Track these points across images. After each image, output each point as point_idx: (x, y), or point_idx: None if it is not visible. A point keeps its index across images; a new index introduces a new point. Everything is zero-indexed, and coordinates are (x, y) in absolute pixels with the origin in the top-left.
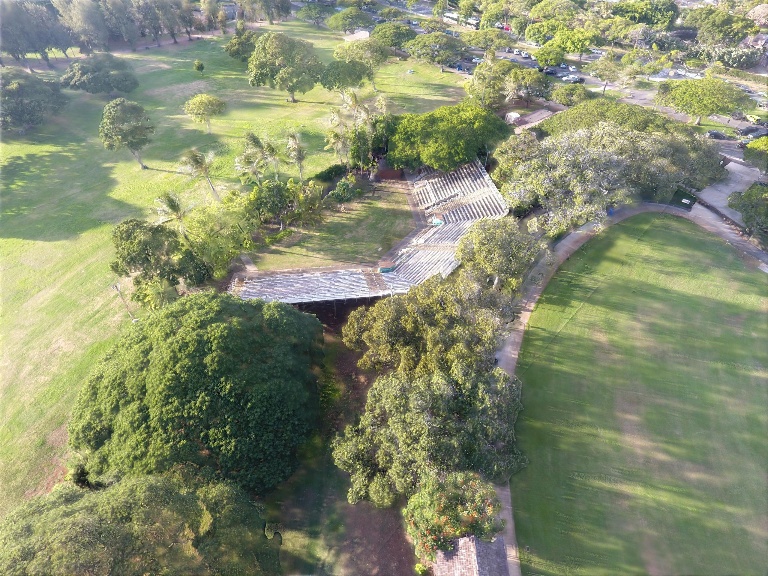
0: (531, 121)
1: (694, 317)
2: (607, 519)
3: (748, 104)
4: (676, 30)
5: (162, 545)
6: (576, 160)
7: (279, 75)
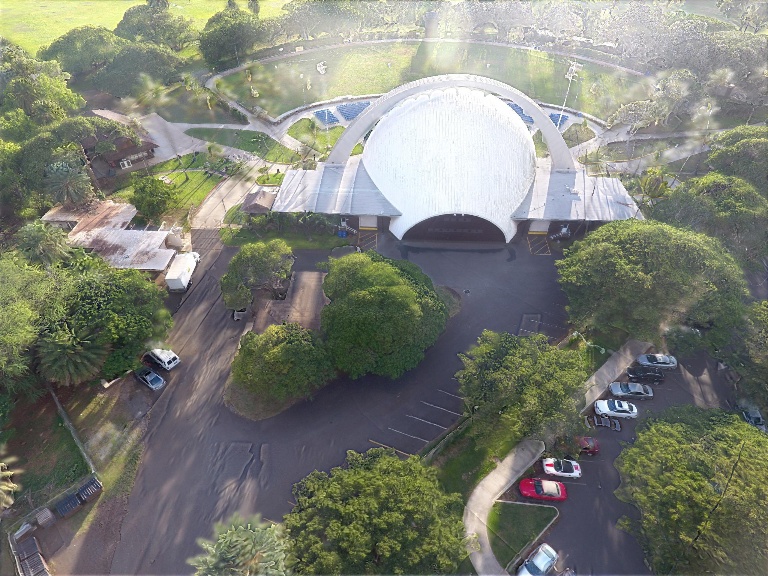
0: None
1: None
2: None
3: None
4: None
5: (434, 4)
6: None
7: (727, 0)
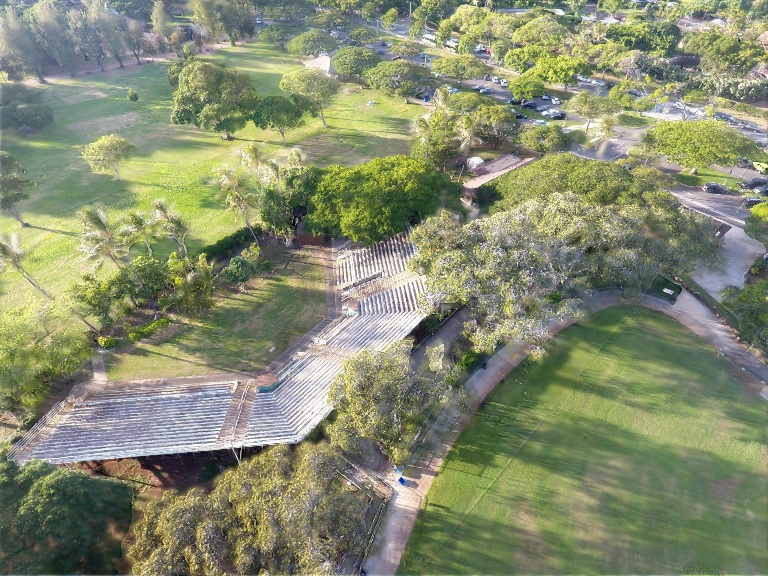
0: (493, 170)
1: (666, 483)
2: None
3: (754, 154)
4: (677, 56)
5: None
6: (509, 256)
7: (203, 112)
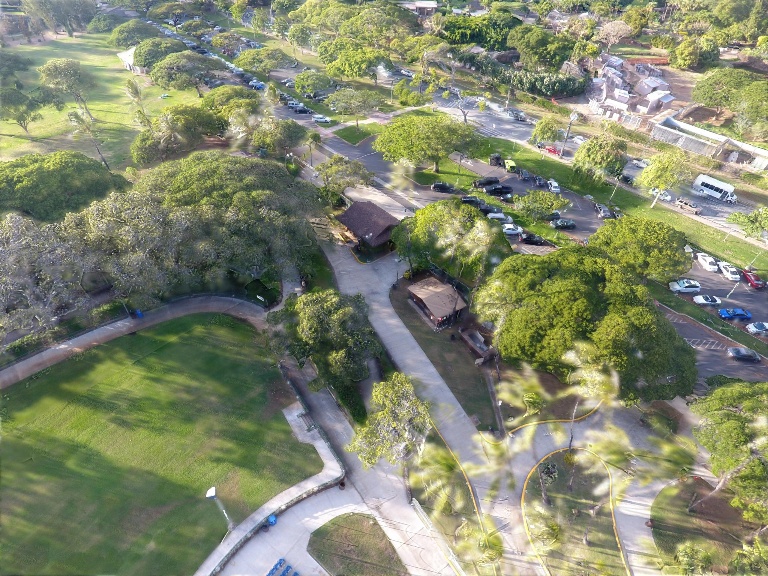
0: None
1: (80, 511)
2: None
3: (472, 151)
4: (509, 50)
5: None
6: None
7: None
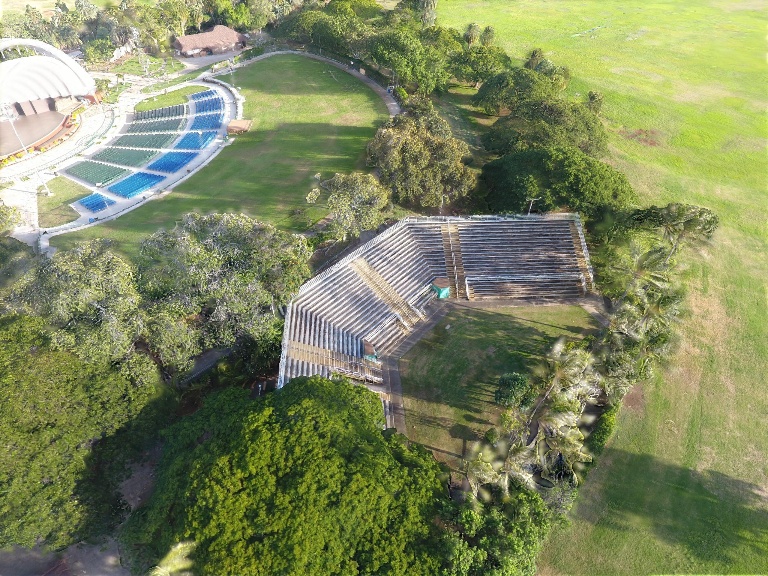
0: None
1: None
2: None
3: None
4: None
5: None
6: None
7: None
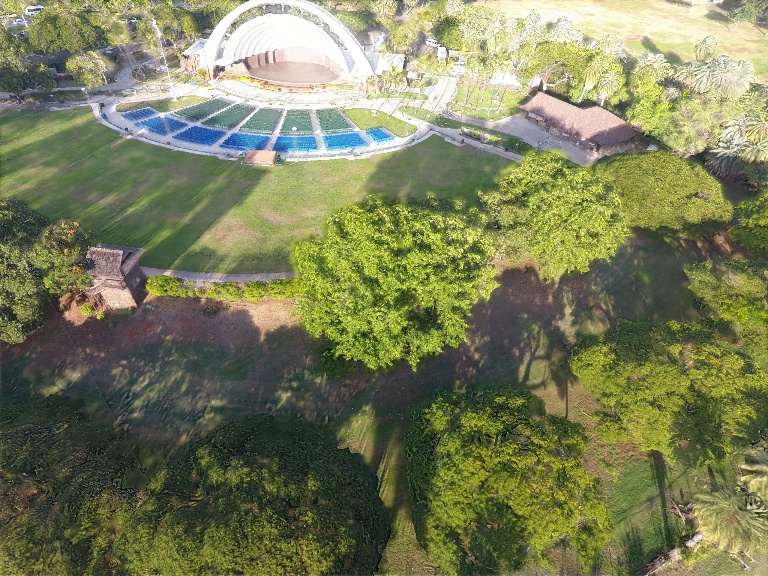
0: None
1: (55, 147)
2: (135, 226)
3: None
4: None
5: None
6: None
7: None
